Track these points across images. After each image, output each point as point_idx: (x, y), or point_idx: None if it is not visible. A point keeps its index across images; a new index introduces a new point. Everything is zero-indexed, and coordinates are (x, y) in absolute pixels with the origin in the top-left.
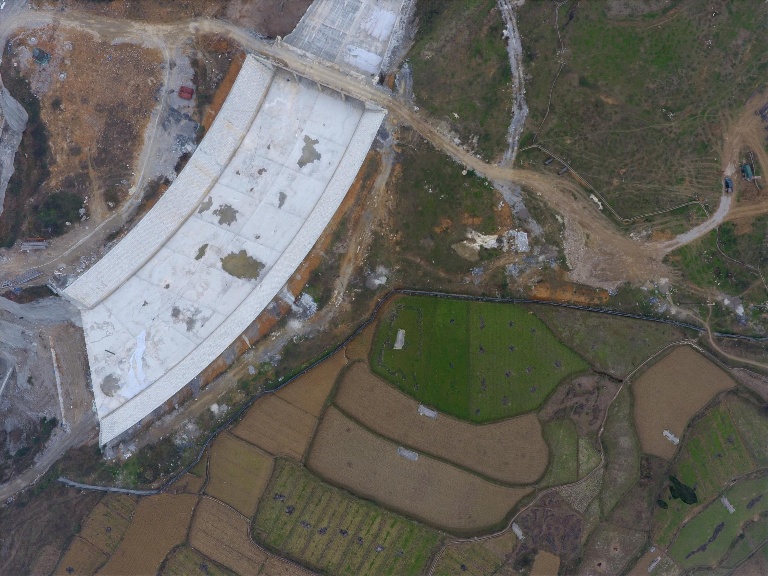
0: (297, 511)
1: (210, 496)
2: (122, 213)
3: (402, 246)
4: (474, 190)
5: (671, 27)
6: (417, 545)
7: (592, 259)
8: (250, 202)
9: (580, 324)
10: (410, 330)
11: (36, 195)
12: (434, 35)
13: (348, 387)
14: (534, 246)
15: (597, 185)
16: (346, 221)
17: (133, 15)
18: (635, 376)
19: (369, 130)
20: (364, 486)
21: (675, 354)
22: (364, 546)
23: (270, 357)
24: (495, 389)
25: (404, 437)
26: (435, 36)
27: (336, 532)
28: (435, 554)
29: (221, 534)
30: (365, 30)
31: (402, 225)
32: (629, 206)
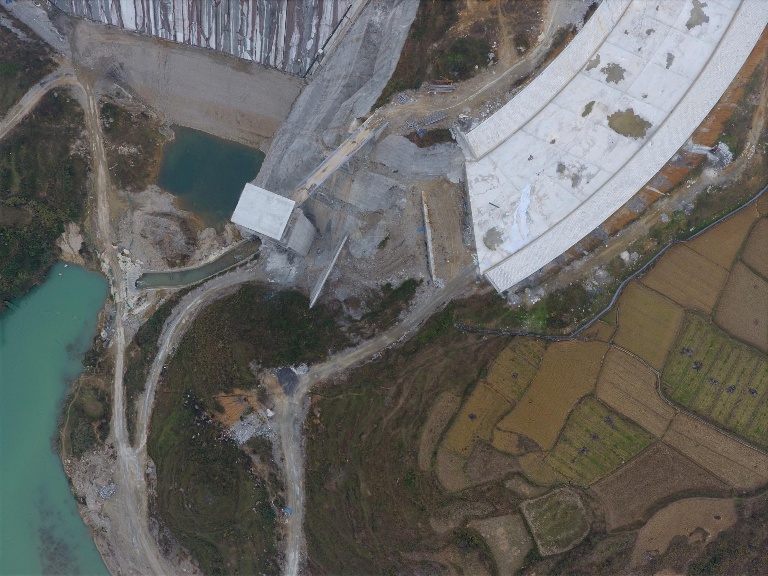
0: (705, 367)
1: (619, 346)
2: (531, 59)
3: None
4: None
5: None
6: None
7: None
8: (638, 61)
9: None
10: None
11: (441, 40)
12: None
13: (754, 243)
14: None
15: None
16: (760, 73)
17: None
18: None
19: None
20: None
21: None
22: None
23: (684, 205)
24: None
25: None
26: None
27: (745, 391)
28: None
29: (629, 386)
30: None
31: None
32: None
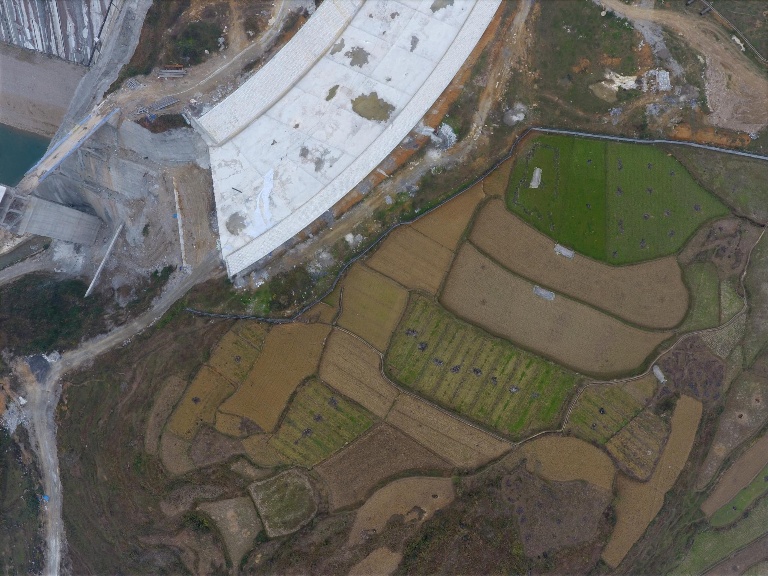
0: (430, 348)
1: (342, 328)
2: (261, 43)
3: (540, 85)
4: (613, 31)
5: None
6: (553, 387)
7: (734, 101)
8: (382, 45)
9: (721, 167)
10: (547, 169)
11: (175, 25)
12: None
13: (483, 224)
14: (675, 86)
15: (740, 26)
16: (486, 55)
17: None
18: None
19: None
20: (498, 325)
21: None
22: (498, 386)
23: (408, 187)
24: (633, 231)
25: (540, 277)
26: None
27: (470, 371)
28: (572, 396)
29: (352, 368)
30: None
31: (540, 64)
32: None
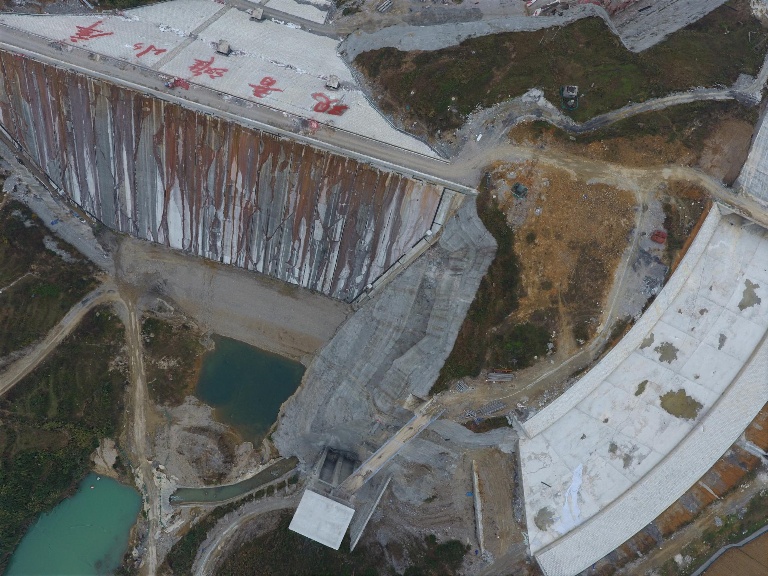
0: None
1: None
2: (589, 350)
3: None
4: None
5: None
6: None
7: None
8: (691, 341)
9: None
10: None
11: (501, 325)
12: None
13: None
14: None
15: None
16: None
17: (610, 158)
18: None
19: None
20: None
21: None
22: None
23: (738, 510)
24: None
25: None
26: None
27: None
28: None
29: None
30: None
31: None
32: None
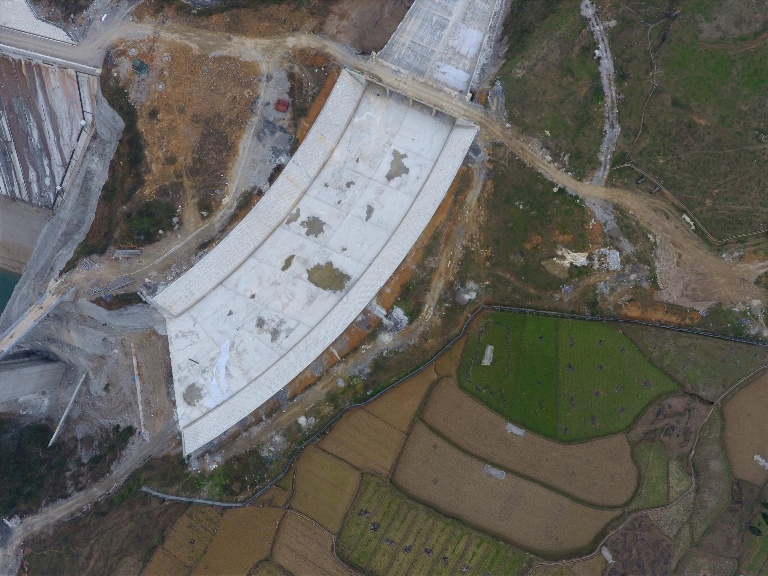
0: (382, 528)
1: (295, 510)
2: (215, 222)
3: (492, 262)
4: (565, 207)
5: (763, 50)
6: (503, 566)
7: (684, 279)
8: (338, 214)
9: (670, 344)
10: (498, 346)
11: (129, 203)
12: (526, 54)
13: (435, 402)
14: (625, 265)
15: (690, 205)
16: (438, 235)
17: (232, 29)
18: (726, 398)
19: (460, 146)
20: (450, 504)
21: (766, 377)
22: (449, 566)
23: (360, 370)
24: (583, 408)
25: (491, 455)
26: (527, 55)
27: (421, 551)
28: None
29: (305, 550)
30: (453, 47)
31: (492, 241)
32: (722, 227)
